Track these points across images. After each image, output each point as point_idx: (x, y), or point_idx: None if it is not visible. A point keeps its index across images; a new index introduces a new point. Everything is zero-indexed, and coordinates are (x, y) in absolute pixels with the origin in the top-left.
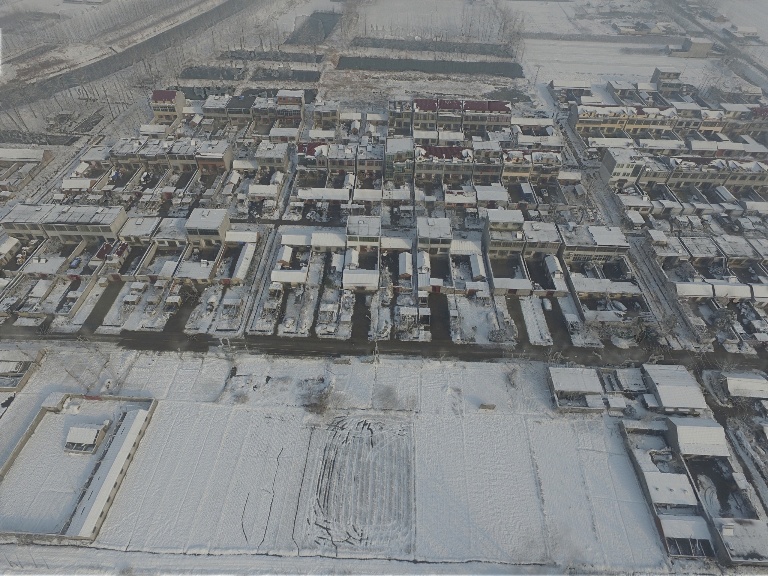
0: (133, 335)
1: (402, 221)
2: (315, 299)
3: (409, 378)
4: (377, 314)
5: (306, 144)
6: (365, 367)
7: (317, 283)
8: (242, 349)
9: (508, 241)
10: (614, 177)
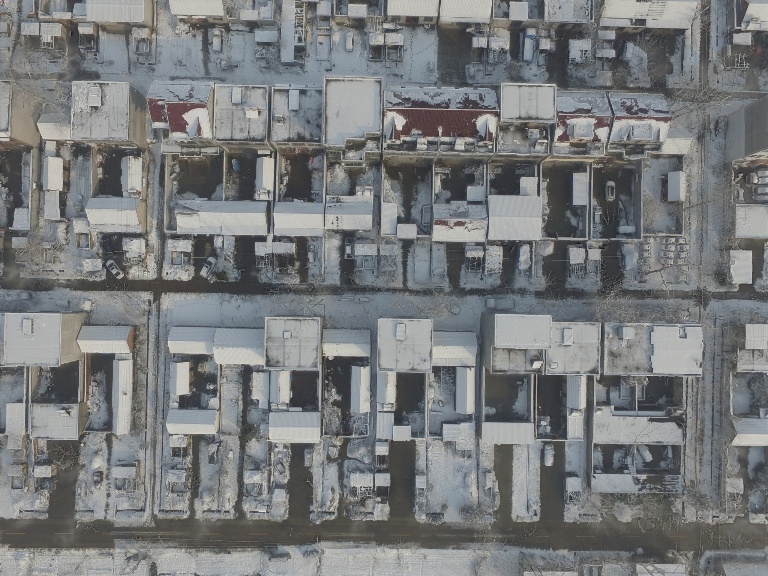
0: (14, 526)
1: (358, 278)
2: (236, 454)
3: (359, 571)
4: (321, 477)
5: (164, 102)
6: (308, 561)
7: (235, 424)
8: (156, 543)
9: (517, 373)
10: (748, 158)
